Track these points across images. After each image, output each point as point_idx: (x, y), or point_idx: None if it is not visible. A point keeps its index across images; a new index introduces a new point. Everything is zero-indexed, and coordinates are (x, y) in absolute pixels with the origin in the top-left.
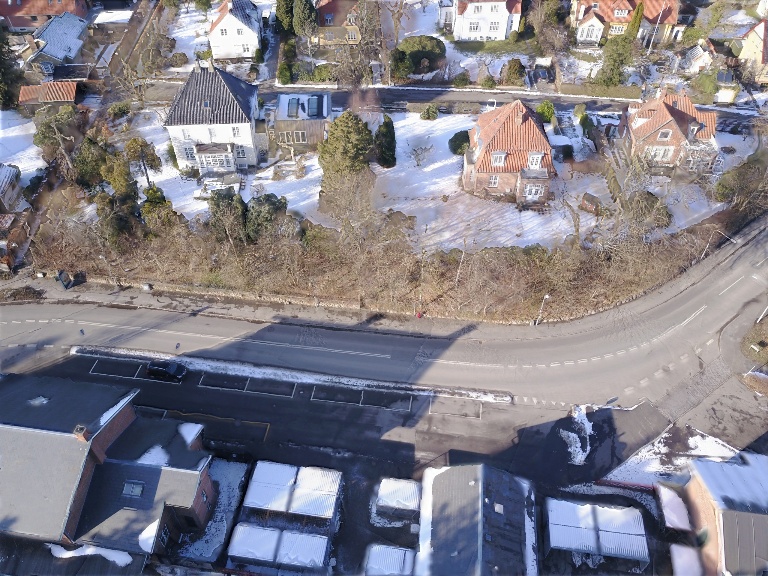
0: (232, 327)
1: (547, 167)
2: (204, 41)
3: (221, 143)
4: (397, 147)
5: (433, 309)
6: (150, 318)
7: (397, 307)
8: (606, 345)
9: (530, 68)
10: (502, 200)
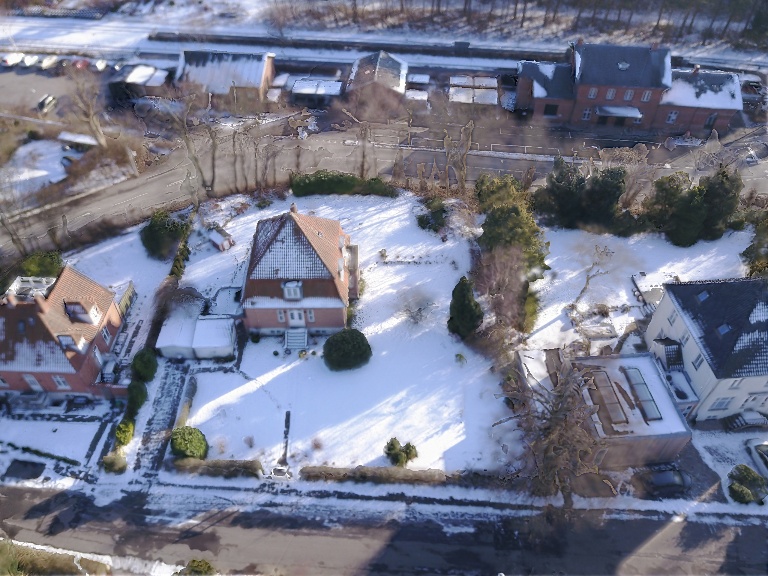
0: None
1: None
2: None
3: None
4: None
5: None
6: None
7: None
8: None
9: None
10: None
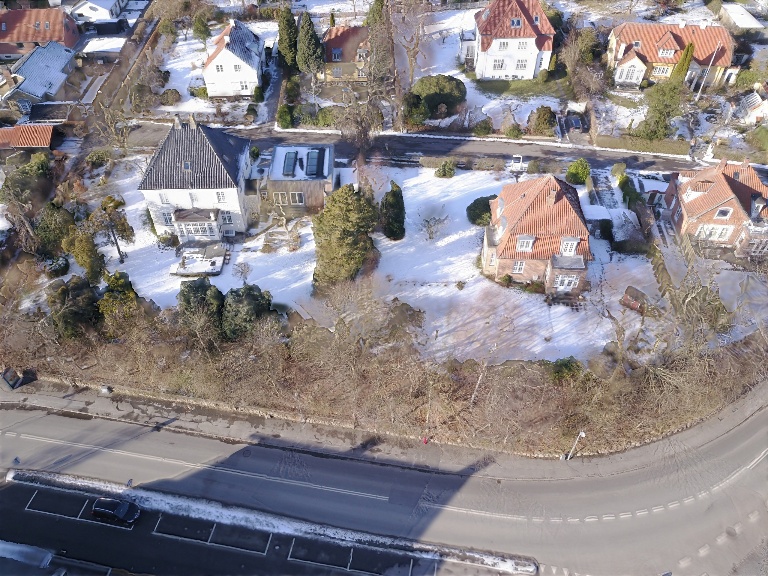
0: (201, 448)
1: (583, 254)
2: (200, 74)
3: (204, 209)
4: (406, 217)
5: (442, 434)
6: (105, 432)
7: (399, 429)
8: (655, 493)
9: (561, 114)
10: (528, 289)
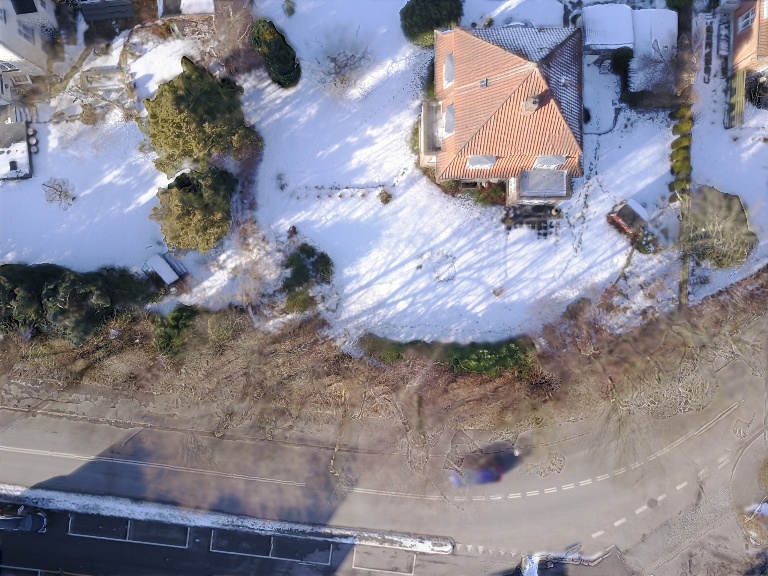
0: (89, 436)
1: (568, 170)
2: None
3: None
4: (298, 60)
5: None
6: None
7: None
8: (586, 466)
9: None
10: (482, 199)
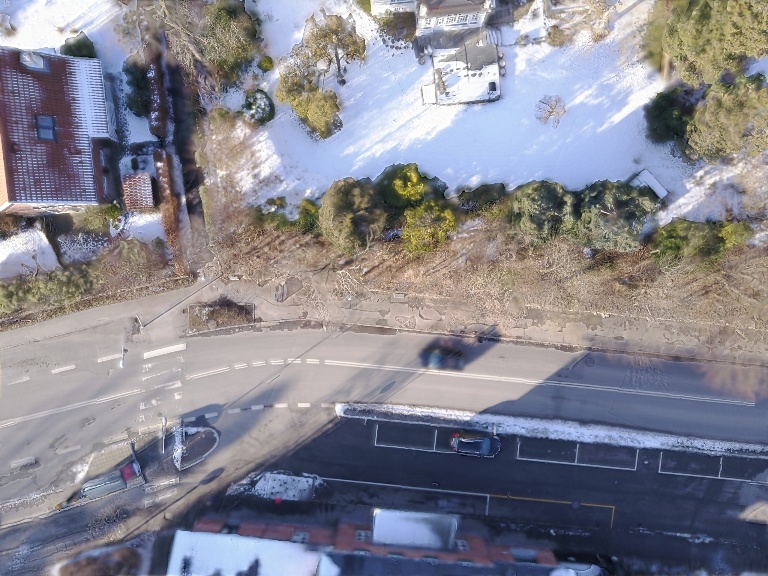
0: (537, 361)
1: None
2: None
3: None
4: None
5: None
6: (421, 350)
7: None
8: None
9: None
10: None
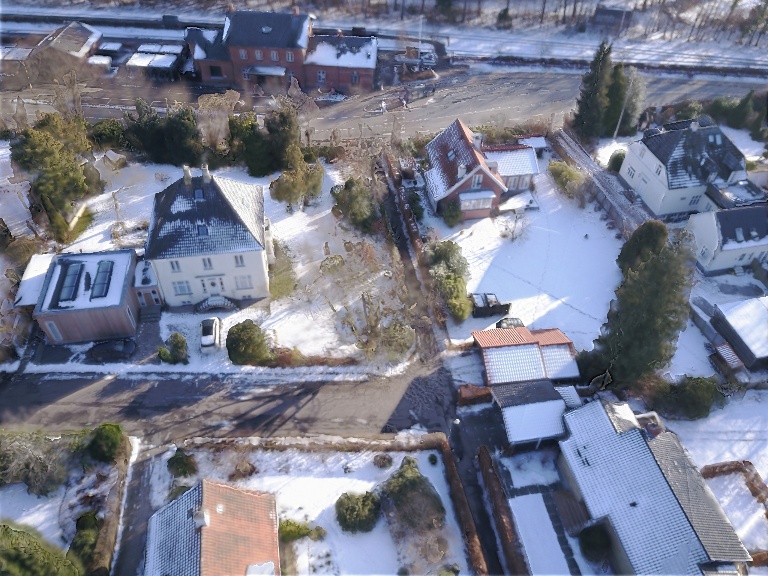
0: None
1: None
2: None
3: None
4: None
5: None
6: None
7: None
8: None
9: None
10: None
